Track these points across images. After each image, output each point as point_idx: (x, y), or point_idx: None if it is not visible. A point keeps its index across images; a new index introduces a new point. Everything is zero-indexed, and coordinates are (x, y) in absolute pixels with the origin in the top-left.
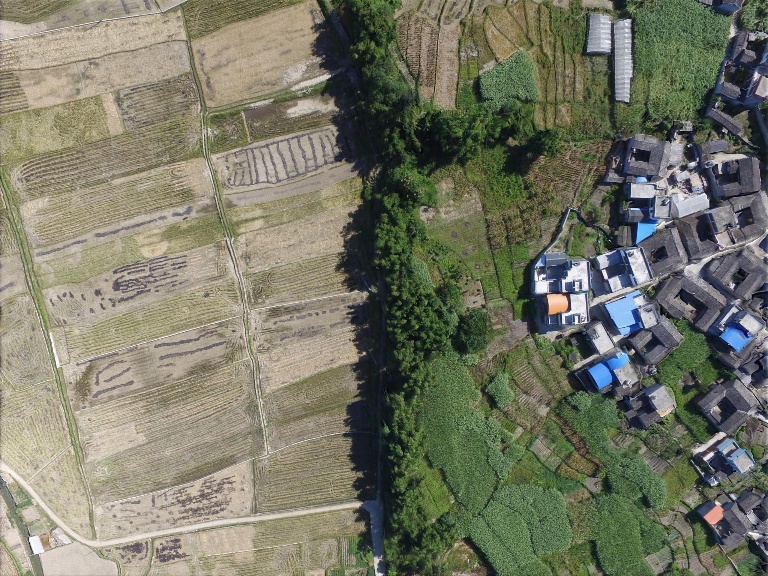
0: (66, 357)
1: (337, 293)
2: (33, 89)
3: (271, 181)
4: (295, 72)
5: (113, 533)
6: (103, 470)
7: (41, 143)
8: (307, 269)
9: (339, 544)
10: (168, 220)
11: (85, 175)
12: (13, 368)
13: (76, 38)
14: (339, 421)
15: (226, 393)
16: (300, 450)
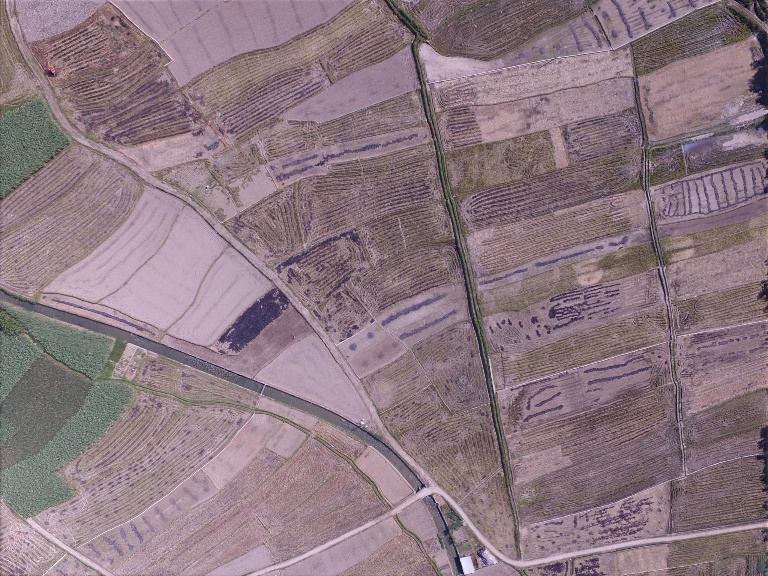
0: (501, 382)
1: (758, 320)
2: (487, 124)
3: (703, 212)
4: (733, 107)
5: (536, 553)
6: (530, 492)
7: (491, 176)
8: (731, 296)
9: (748, 563)
10: (604, 250)
11: (530, 206)
12: (451, 393)
13: (530, 75)
14: (753, 443)
15: (649, 417)
16: (715, 472)
